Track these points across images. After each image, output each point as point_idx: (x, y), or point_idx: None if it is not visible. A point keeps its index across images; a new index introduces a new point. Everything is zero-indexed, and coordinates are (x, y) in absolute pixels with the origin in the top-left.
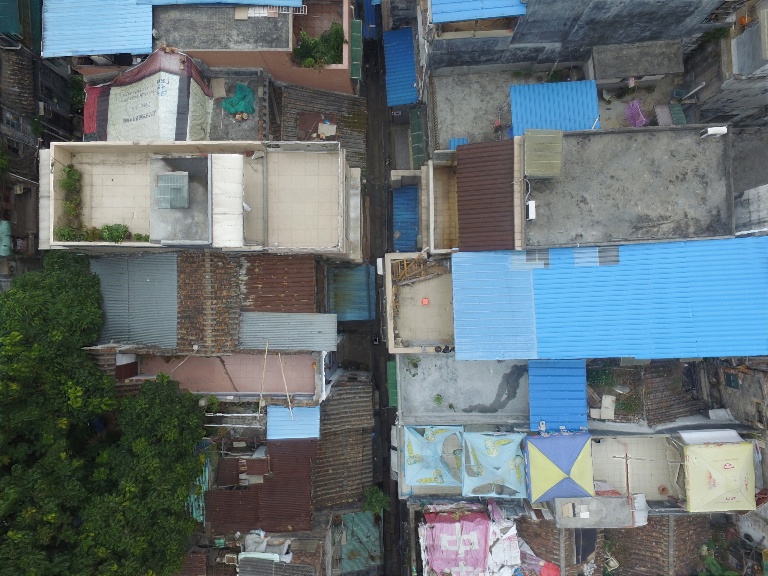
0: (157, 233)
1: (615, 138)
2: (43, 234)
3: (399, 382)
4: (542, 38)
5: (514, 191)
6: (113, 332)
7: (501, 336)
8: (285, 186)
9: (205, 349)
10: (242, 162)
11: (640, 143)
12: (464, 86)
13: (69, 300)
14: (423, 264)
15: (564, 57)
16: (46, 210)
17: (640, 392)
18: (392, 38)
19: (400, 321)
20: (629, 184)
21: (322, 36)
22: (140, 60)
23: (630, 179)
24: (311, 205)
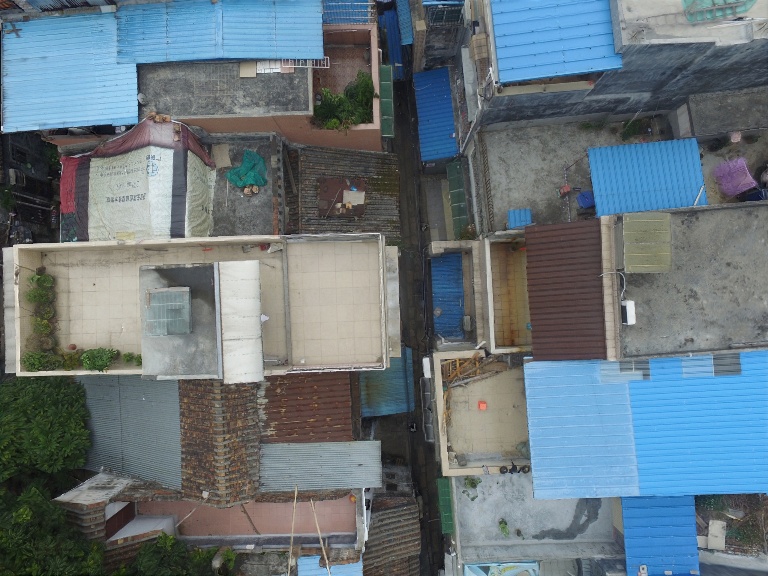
0: (151, 366)
1: (730, 214)
2: (10, 354)
3: (456, 511)
4: (628, 88)
5: (603, 286)
6: (103, 456)
7: (592, 468)
8: (311, 285)
9: (218, 498)
10: (258, 269)
11: (762, 220)
12: (521, 142)
13: (48, 424)
14: (479, 361)
15: (649, 107)
16: (13, 323)
17: (759, 518)
18: (424, 80)
19: (452, 430)
20: (751, 273)
21: (346, 89)
22: (124, 128)
23: (752, 266)
24: (344, 308)
